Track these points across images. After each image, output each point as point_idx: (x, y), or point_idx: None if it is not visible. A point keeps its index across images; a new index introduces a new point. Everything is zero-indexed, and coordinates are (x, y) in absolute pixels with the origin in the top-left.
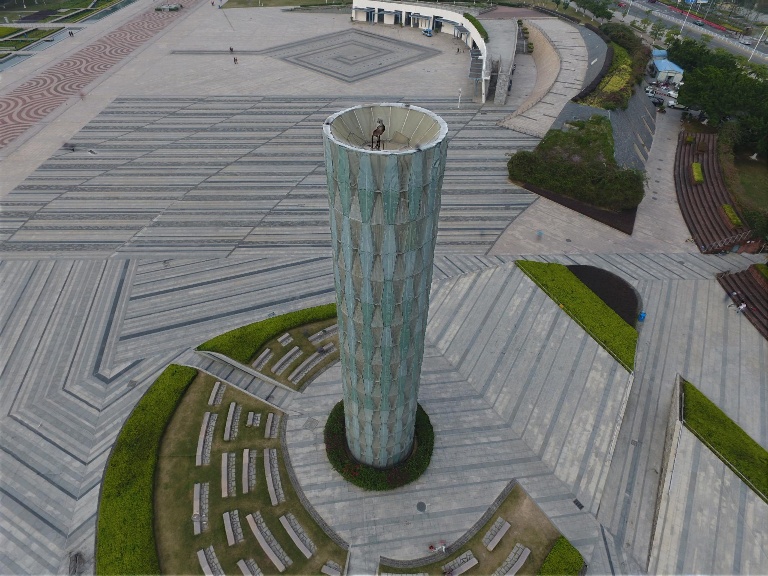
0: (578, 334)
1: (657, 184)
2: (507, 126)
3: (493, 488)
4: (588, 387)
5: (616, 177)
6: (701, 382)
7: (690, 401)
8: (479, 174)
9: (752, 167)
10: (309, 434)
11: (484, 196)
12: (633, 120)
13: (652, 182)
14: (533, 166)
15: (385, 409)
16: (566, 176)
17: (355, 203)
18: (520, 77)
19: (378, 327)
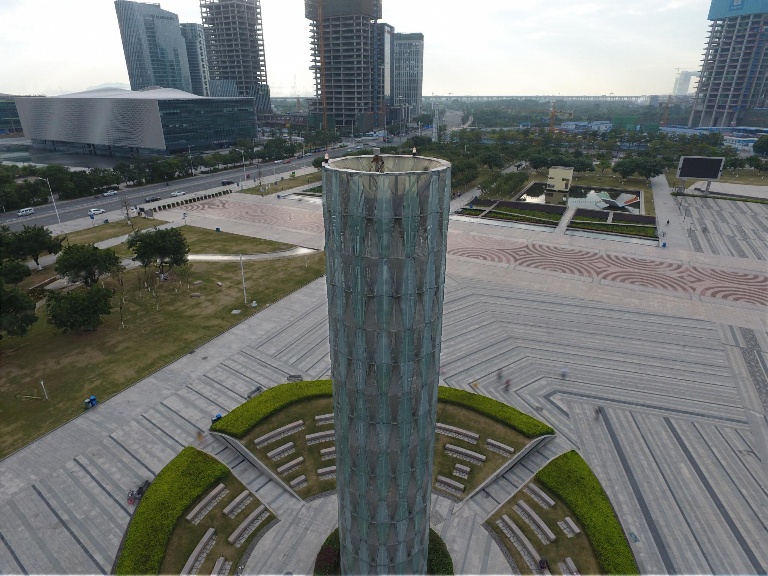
0: None
1: None
2: None
3: None
4: None
5: None
6: None
7: None
8: None
9: None
10: None
11: None
12: None
13: None
14: None
15: None
16: None
17: None
18: None
19: None
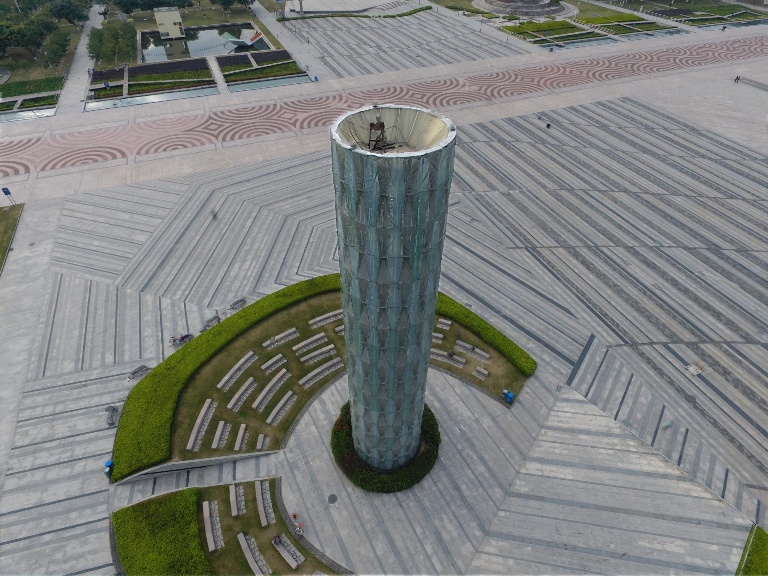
0: None
1: None
2: None
3: (376, 572)
4: None
5: None
6: None
7: None
8: None
9: None
10: None
11: None
12: None
13: None
14: None
15: None
16: None
17: None
18: None
19: None
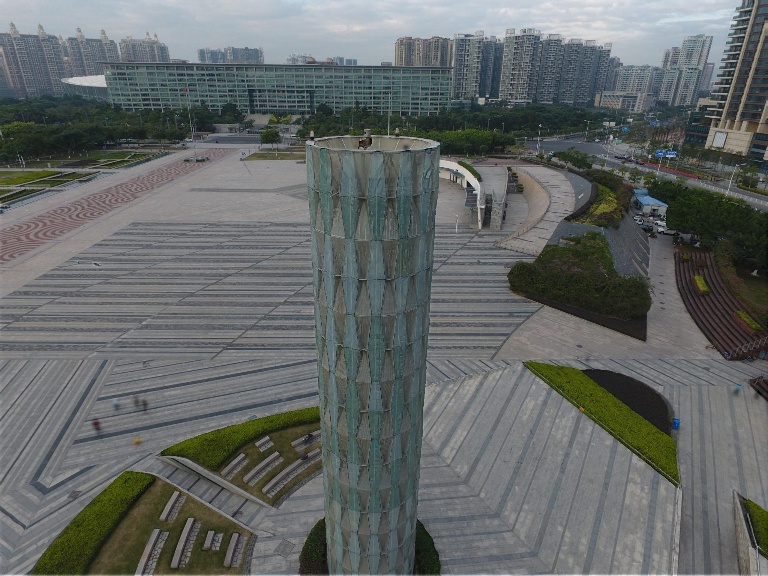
0: (605, 440)
1: (662, 296)
2: (504, 246)
3: None
4: (628, 504)
5: (620, 284)
6: (765, 501)
7: (759, 523)
8: (480, 286)
9: (755, 282)
10: (281, 562)
11: (486, 305)
12: (627, 239)
13: (657, 294)
14: (533, 276)
15: (375, 510)
16: (568, 285)
17: (338, 216)
18: (513, 210)
19: (365, 383)
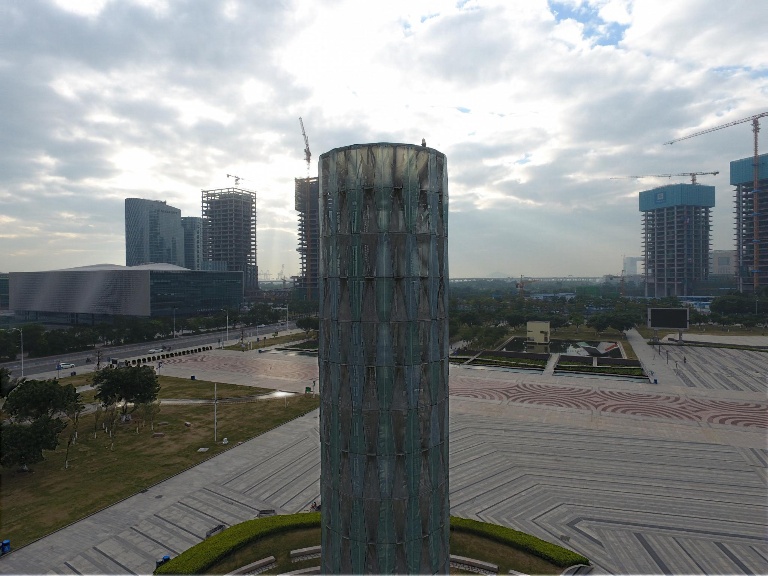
0: None
1: None
2: None
3: None
4: None
5: None
6: None
7: None
8: None
9: None
10: None
11: None
12: None
13: None
14: None
15: None
16: None
17: None
18: None
19: None
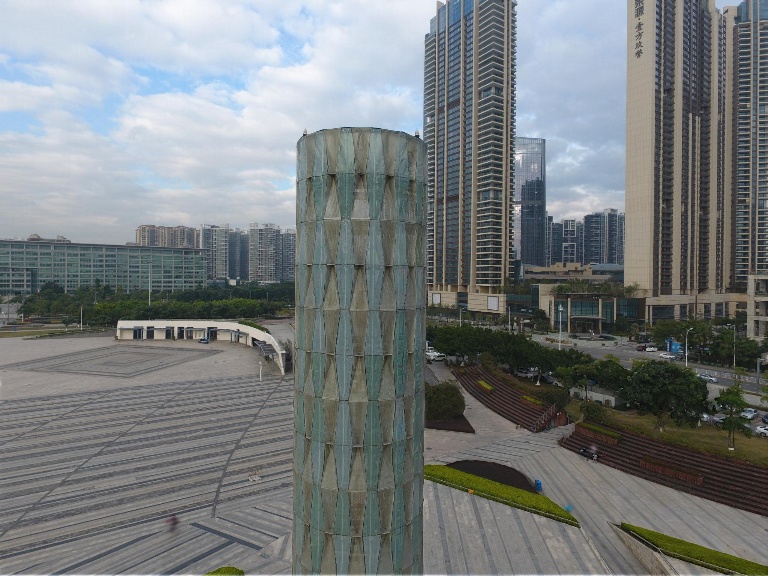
0: (505, 511)
1: None
2: None
3: None
4: (557, 558)
5: (438, 389)
6: (629, 522)
7: (643, 533)
8: None
9: None
10: None
11: None
12: None
13: None
14: None
15: None
16: None
17: (359, 198)
18: None
19: (388, 400)
